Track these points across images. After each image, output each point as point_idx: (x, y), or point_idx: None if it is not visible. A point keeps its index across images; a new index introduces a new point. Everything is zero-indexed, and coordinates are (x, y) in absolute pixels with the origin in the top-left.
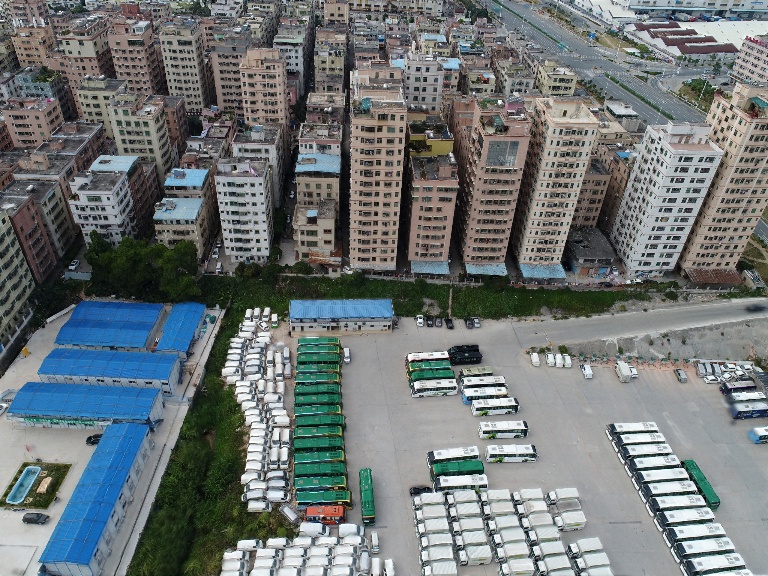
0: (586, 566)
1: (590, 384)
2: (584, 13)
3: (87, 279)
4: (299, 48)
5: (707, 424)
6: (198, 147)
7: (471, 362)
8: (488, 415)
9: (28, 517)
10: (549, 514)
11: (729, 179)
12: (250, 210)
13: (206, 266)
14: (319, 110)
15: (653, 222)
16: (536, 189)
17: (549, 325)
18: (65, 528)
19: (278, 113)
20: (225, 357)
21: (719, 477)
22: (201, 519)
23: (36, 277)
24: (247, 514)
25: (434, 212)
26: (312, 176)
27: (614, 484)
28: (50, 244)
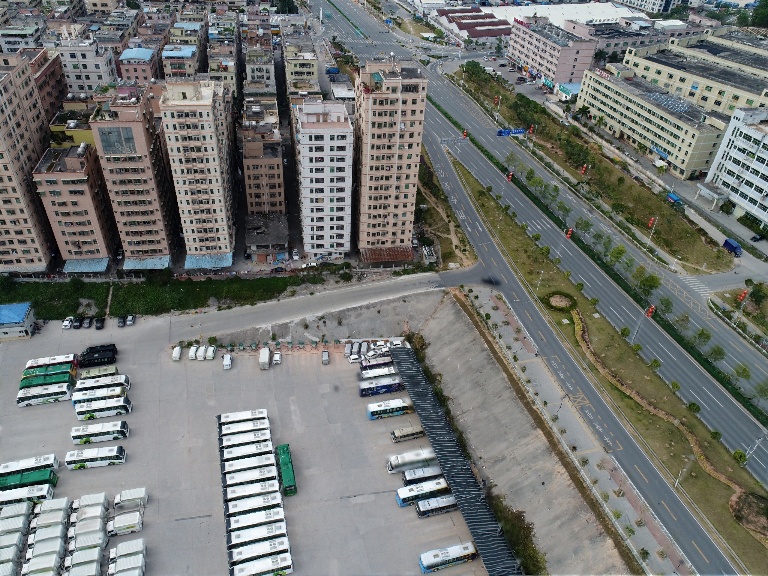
0: (115, 571)
1: (226, 375)
2: (399, 0)
3: None
4: (29, 40)
5: (331, 405)
6: None
7: (103, 363)
8: (96, 418)
9: None
10: (99, 519)
11: (369, 156)
12: None
13: None
14: None
15: (309, 204)
16: (173, 176)
17: (210, 316)
18: None
19: None
20: None
21: (317, 458)
22: None
23: None
24: None
25: (70, 207)
26: None
27: (201, 478)
28: None
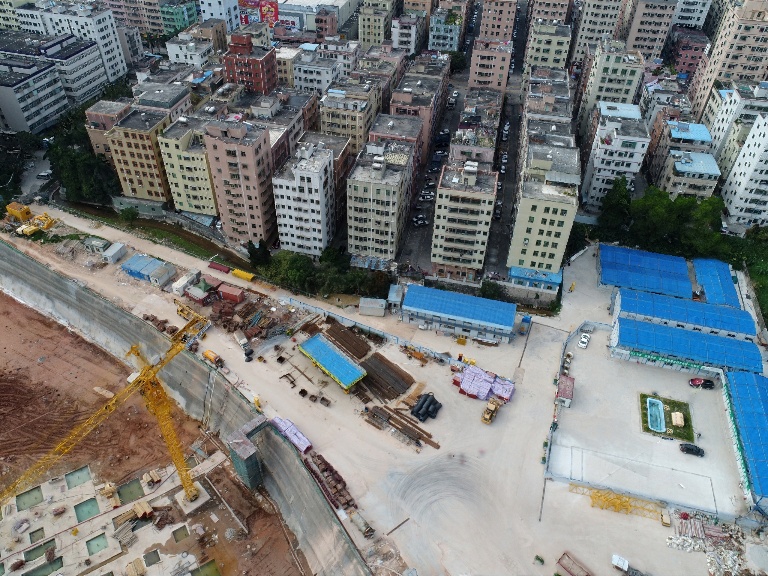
0: None
1: None
2: None
3: (587, 223)
4: (708, 1)
5: None
6: (665, 100)
7: None
8: None
9: (690, 448)
10: None
11: None
12: None
13: None
14: None
15: None
16: None
17: None
18: (762, 467)
19: (757, 70)
20: None
21: None
22: None
23: None
24: None
25: None
26: None
27: None
28: None
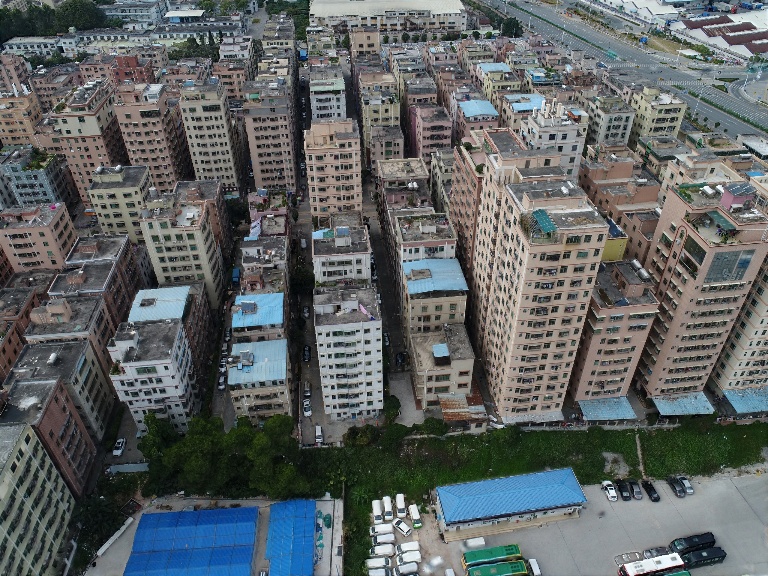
0: None
1: None
2: (616, 12)
3: (141, 470)
4: (341, 96)
5: None
6: (256, 253)
7: (710, 563)
8: None
9: None
10: None
11: None
12: (361, 360)
13: (300, 432)
14: (397, 184)
15: None
16: (763, 303)
17: None
18: None
19: (354, 199)
20: None
21: None
22: None
23: (75, 488)
24: None
25: (619, 343)
26: (430, 296)
27: None
28: (85, 427)
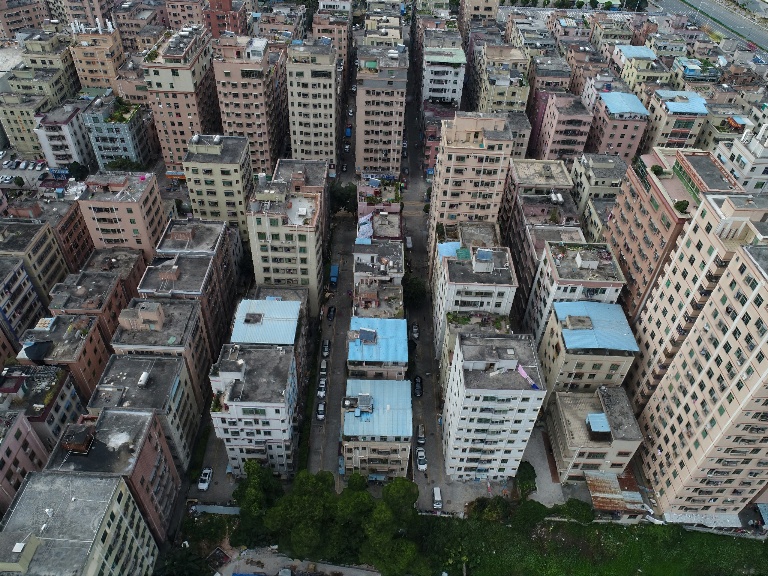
0: None
1: None
2: None
3: (230, 513)
4: (461, 70)
5: None
6: (369, 260)
7: None
8: None
9: None
10: None
11: None
12: (507, 428)
13: None
14: (535, 192)
15: None
16: None
17: None
18: None
19: (489, 208)
20: None
21: None
22: None
23: (159, 534)
24: None
25: None
26: (589, 351)
27: None
28: None
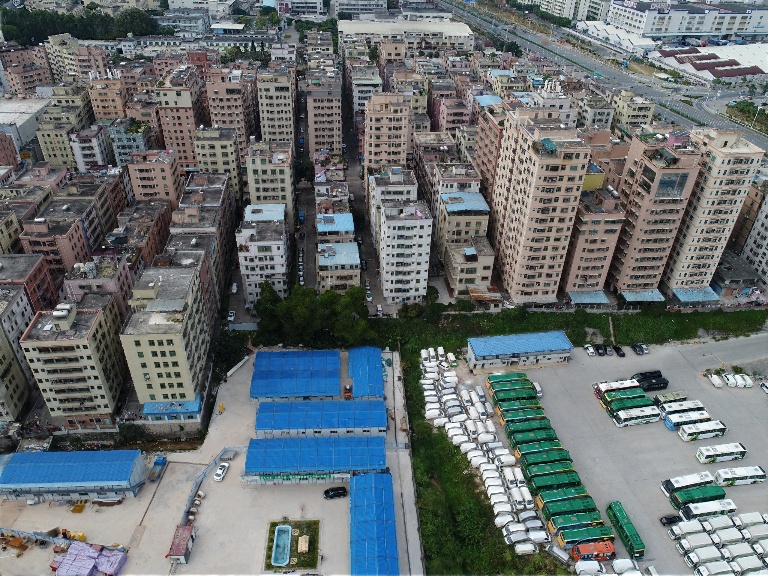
0: None
1: None
2: (602, 42)
3: (250, 329)
4: (379, 89)
5: None
6: (325, 191)
7: (658, 388)
8: (697, 439)
9: None
10: None
11: None
12: (415, 252)
13: None
14: (431, 149)
15: None
16: (697, 217)
17: (713, 347)
18: None
19: (400, 154)
20: (423, 400)
21: None
22: (473, 566)
23: (210, 331)
24: (518, 557)
25: (598, 244)
26: (462, 215)
27: None
28: None
